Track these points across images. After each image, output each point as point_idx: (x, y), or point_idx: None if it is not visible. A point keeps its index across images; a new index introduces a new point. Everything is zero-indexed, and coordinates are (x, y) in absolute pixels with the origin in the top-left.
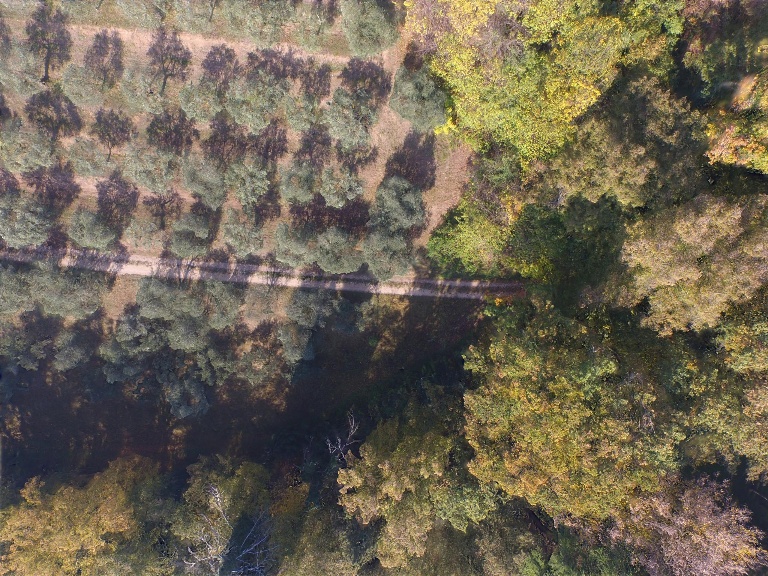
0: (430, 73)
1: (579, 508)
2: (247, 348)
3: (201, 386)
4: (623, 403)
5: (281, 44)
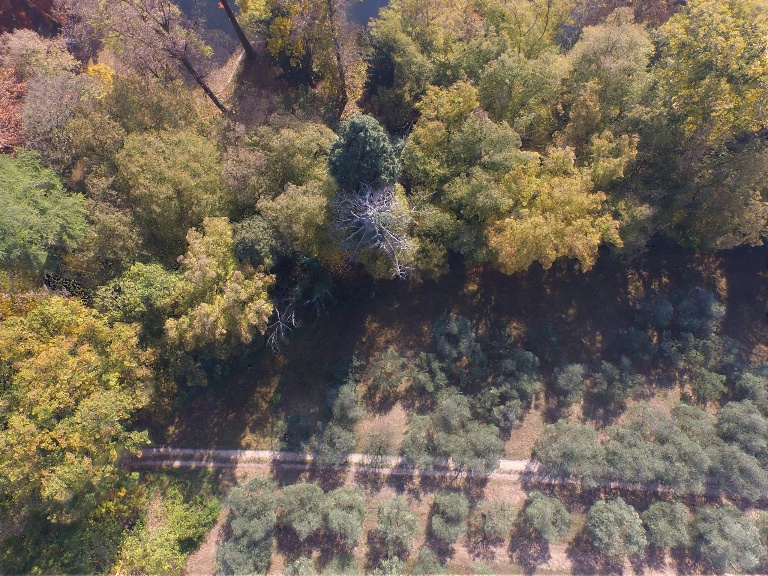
0: None
1: (5, 331)
2: (403, 383)
3: (440, 352)
4: None
5: None
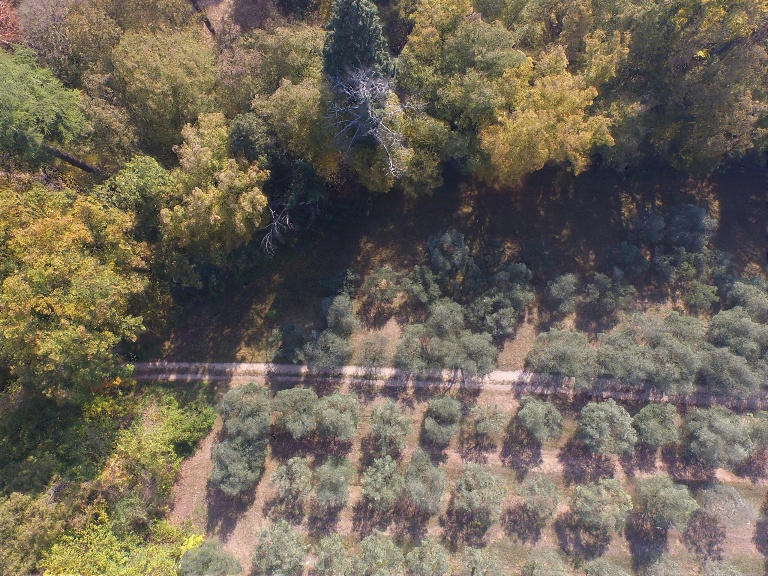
0: None
1: (1, 201)
2: (398, 300)
3: (434, 264)
4: None
5: None
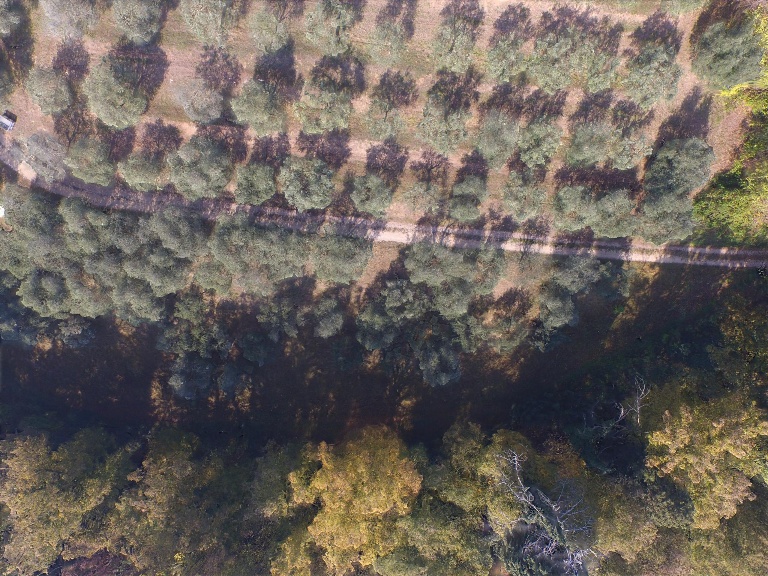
0: None
1: None
2: (489, 317)
3: (457, 354)
4: None
5: (580, 2)
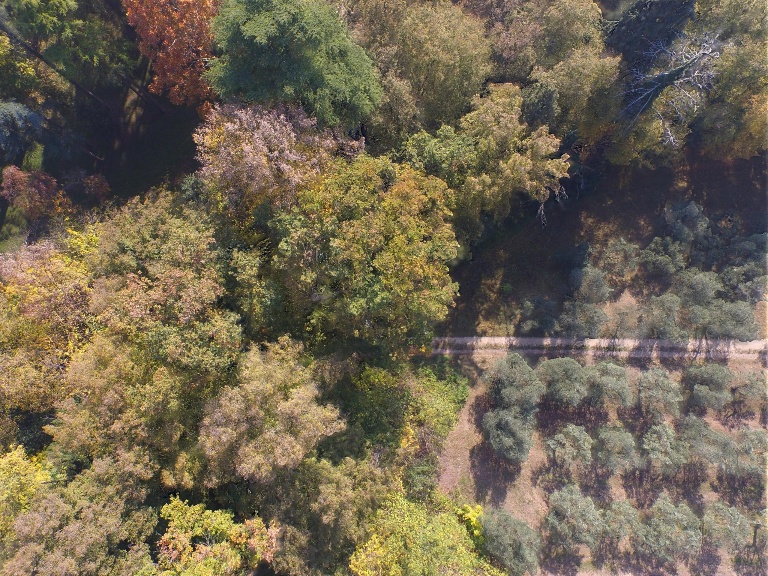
0: (507, 571)
1: None
2: (628, 273)
3: (677, 235)
4: (335, 272)
5: None
